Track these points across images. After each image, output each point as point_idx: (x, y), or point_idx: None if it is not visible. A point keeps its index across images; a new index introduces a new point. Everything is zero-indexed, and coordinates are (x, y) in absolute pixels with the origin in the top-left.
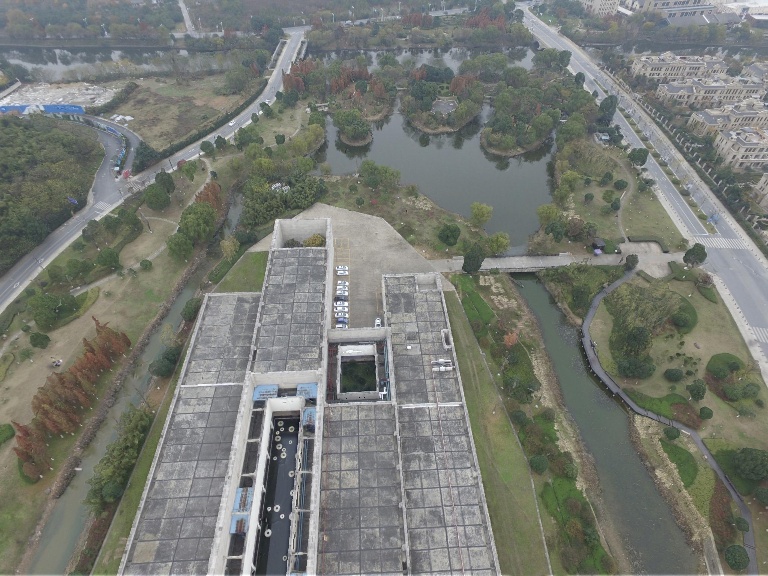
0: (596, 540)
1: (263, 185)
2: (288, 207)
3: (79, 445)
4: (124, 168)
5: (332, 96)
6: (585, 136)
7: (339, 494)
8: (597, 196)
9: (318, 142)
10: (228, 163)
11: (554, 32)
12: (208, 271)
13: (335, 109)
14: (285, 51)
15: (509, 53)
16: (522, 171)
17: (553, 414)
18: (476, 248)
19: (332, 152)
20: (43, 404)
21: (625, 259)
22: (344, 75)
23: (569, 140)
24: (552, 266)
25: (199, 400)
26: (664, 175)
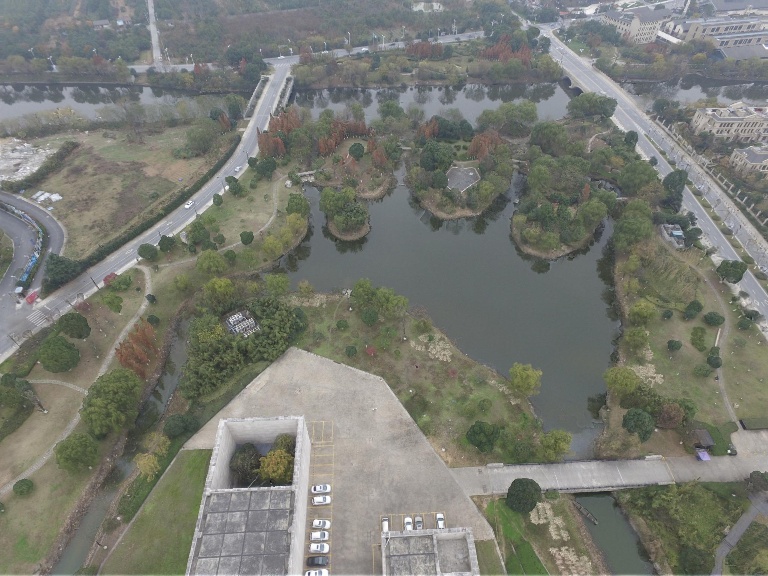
0: None
1: (214, 329)
2: (249, 359)
3: None
4: (32, 285)
5: (320, 160)
6: (653, 234)
7: None
8: (683, 339)
9: (299, 235)
10: (171, 283)
11: (587, 65)
12: (121, 487)
13: (323, 180)
14: (266, 92)
15: (534, 90)
16: (563, 267)
17: None
18: (522, 452)
19: (318, 241)
20: None
21: (744, 467)
22: (335, 132)
23: (633, 242)
24: (638, 484)
25: None
26: (766, 296)
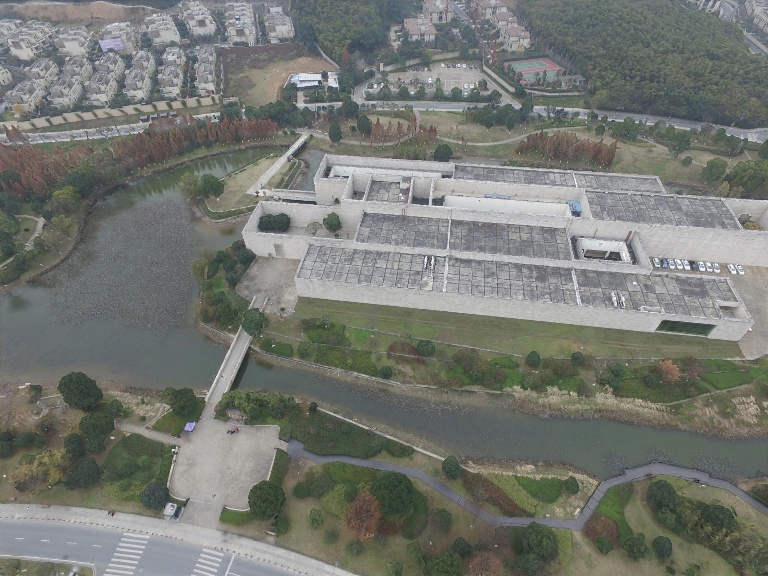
0: (473, 372)
1: None
2: None
3: (538, 162)
4: None
5: None
6: None
7: (505, 231)
8: None
9: None
10: None
11: None
12: None
13: None
14: None
15: None
16: None
17: (586, 391)
18: None
19: None
20: (556, 137)
21: None
22: None
23: None
24: None
25: (564, 180)
26: None
